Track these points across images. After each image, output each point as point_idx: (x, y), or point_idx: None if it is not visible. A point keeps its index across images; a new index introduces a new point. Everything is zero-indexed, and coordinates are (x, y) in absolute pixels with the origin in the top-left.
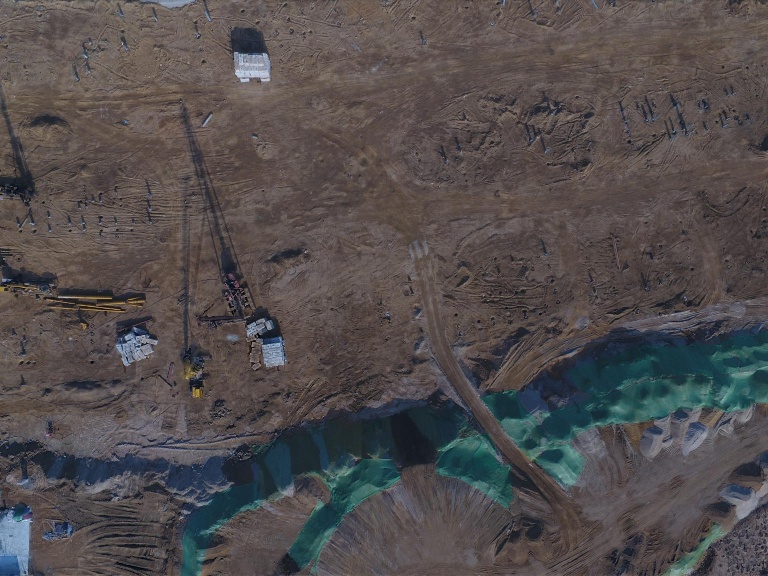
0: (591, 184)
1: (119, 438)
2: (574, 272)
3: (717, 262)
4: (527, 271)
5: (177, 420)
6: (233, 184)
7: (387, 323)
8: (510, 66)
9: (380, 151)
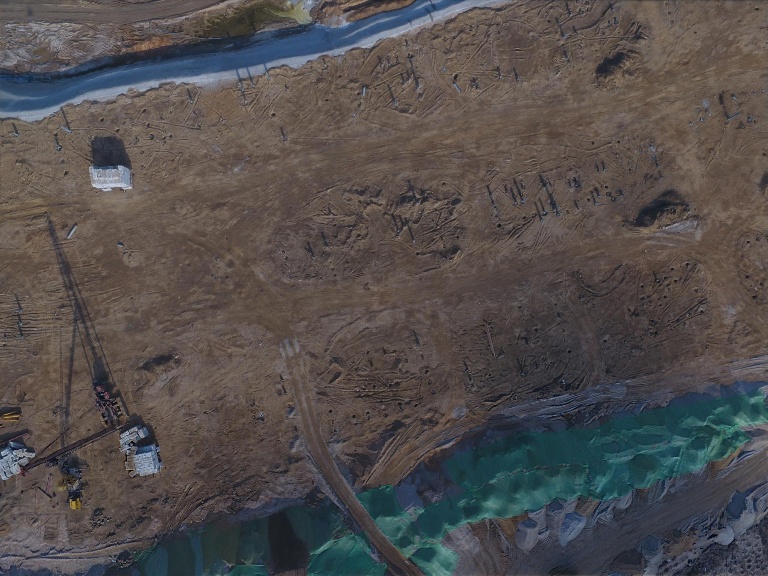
0: (462, 271)
1: (3, 550)
2: (448, 361)
3: (595, 343)
4: (400, 363)
5: (58, 530)
6: (101, 293)
7: (261, 423)
8: (374, 157)
9: (246, 251)
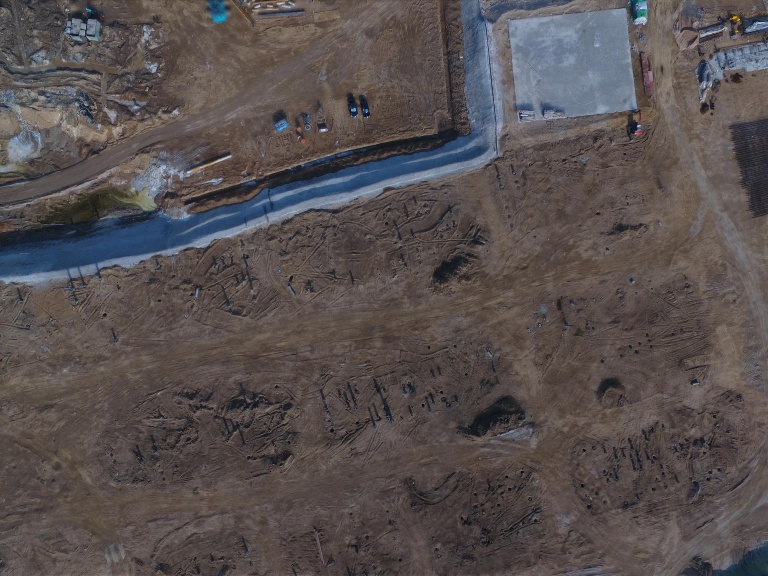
0: (293, 476)
1: None
2: (277, 568)
3: (426, 551)
4: (227, 570)
5: None
6: None
7: None
8: (206, 359)
9: (74, 453)
